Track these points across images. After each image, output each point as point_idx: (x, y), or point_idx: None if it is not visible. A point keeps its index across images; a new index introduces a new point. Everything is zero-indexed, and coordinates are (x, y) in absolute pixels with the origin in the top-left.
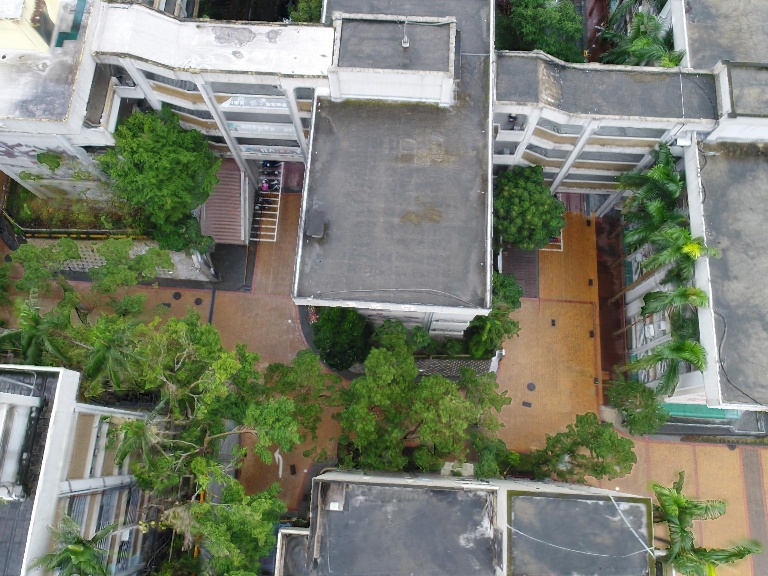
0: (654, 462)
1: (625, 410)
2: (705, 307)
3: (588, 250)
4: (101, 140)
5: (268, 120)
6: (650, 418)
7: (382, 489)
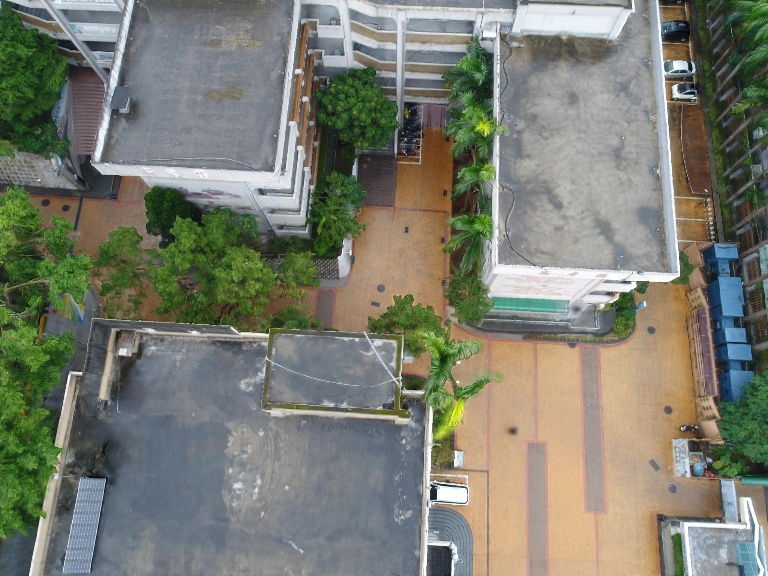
0: (495, 358)
1: (458, 303)
2: (492, 180)
3: (445, 163)
4: None
5: (110, 22)
6: (476, 307)
7: (173, 340)
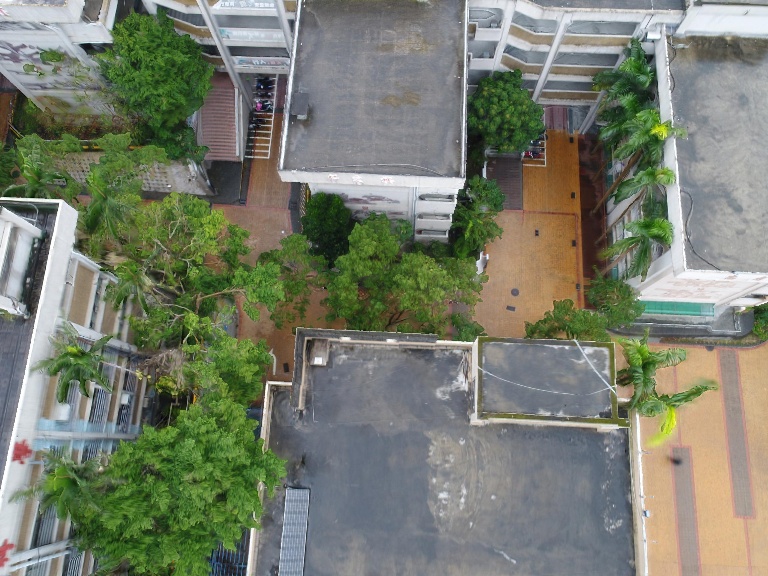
0: None
1: (604, 307)
2: (672, 184)
3: (571, 165)
4: (100, 37)
5: (258, 27)
6: (627, 311)
7: (364, 349)
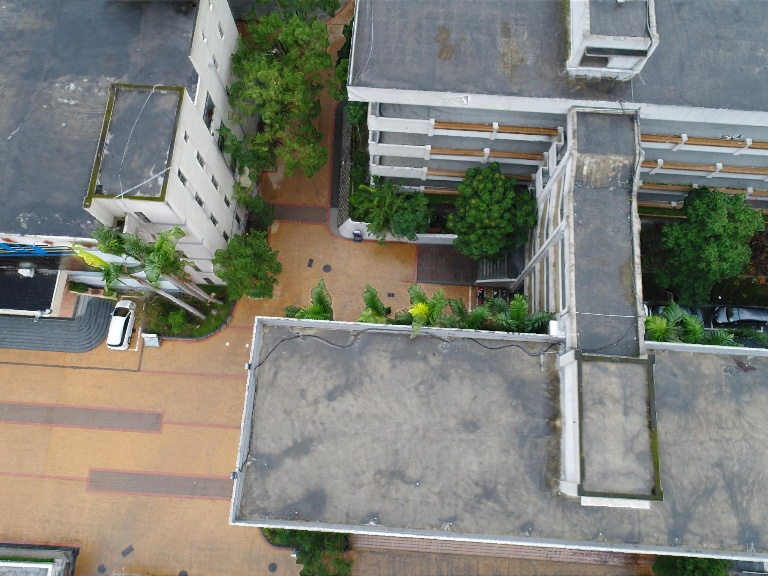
0: None
1: None
2: (358, 319)
3: None
4: None
5: None
6: None
7: None
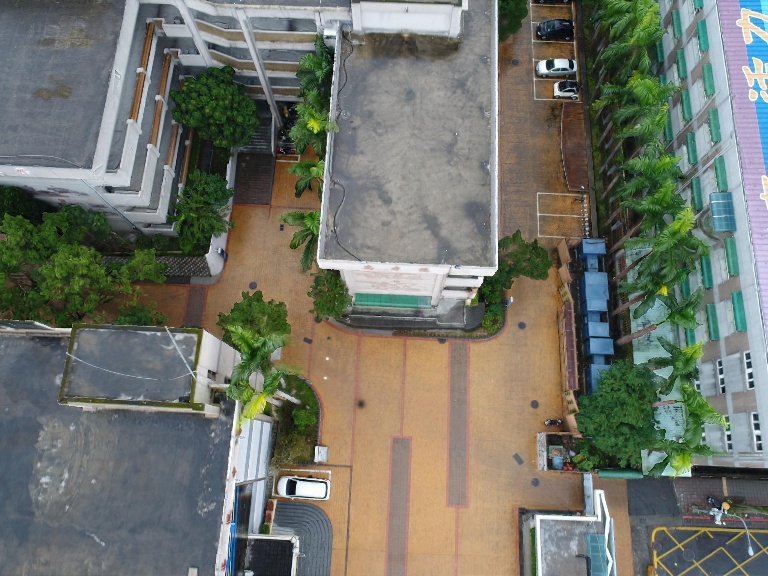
0: (364, 354)
1: None
2: (321, 176)
3: None
4: None
5: None
6: (334, 303)
7: None
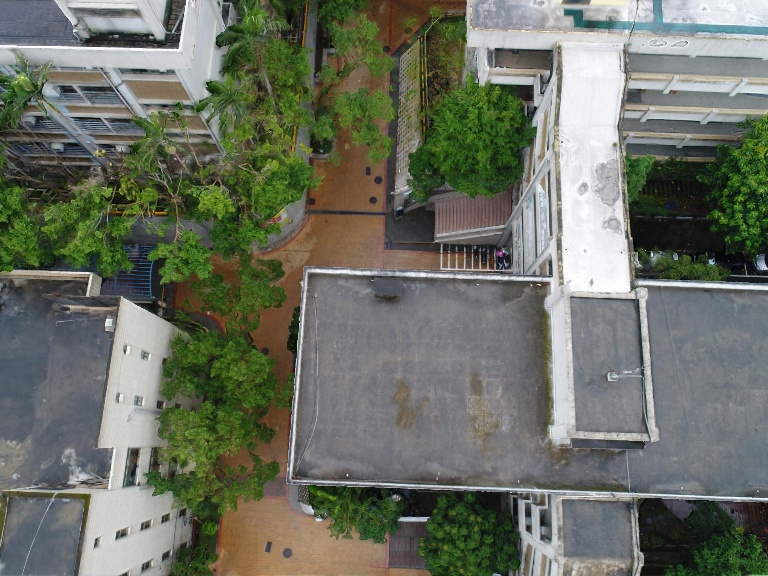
0: None
1: None
2: None
3: None
4: None
5: None
6: None
7: None
